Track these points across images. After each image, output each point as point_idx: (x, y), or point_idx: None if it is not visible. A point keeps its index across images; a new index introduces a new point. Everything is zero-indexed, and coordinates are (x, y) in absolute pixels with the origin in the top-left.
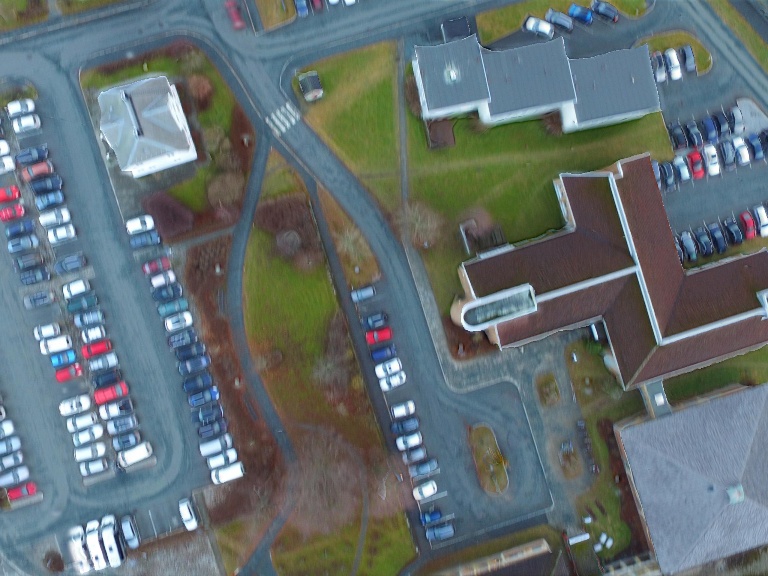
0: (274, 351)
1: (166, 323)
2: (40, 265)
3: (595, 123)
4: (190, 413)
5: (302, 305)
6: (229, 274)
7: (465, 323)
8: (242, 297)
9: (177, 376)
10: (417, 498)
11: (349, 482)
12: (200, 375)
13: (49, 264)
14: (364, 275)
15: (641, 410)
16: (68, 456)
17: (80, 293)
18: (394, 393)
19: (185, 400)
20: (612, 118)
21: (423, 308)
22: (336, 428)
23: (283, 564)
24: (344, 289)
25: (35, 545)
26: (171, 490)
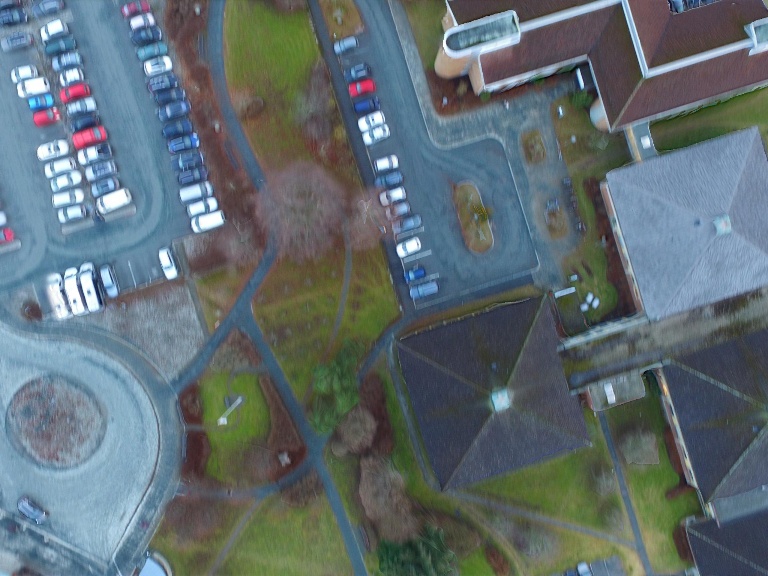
0: (255, 97)
1: (145, 66)
2: (17, 6)
3: None
4: (170, 161)
5: (283, 52)
6: (209, 20)
7: (447, 48)
8: (223, 44)
9: (157, 123)
10: (401, 255)
11: (331, 234)
12: (180, 120)
13: (27, 7)
14: (347, 27)
15: (627, 160)
16: (46, 204)
17: (58, 33)
18: (377, 149)
19: (165, 148)
20: None
21: (407, 62)
22: (318, 178)
23: (264, 316)
24: (326, 41)
25: (13, 294)
26: (151, 240)
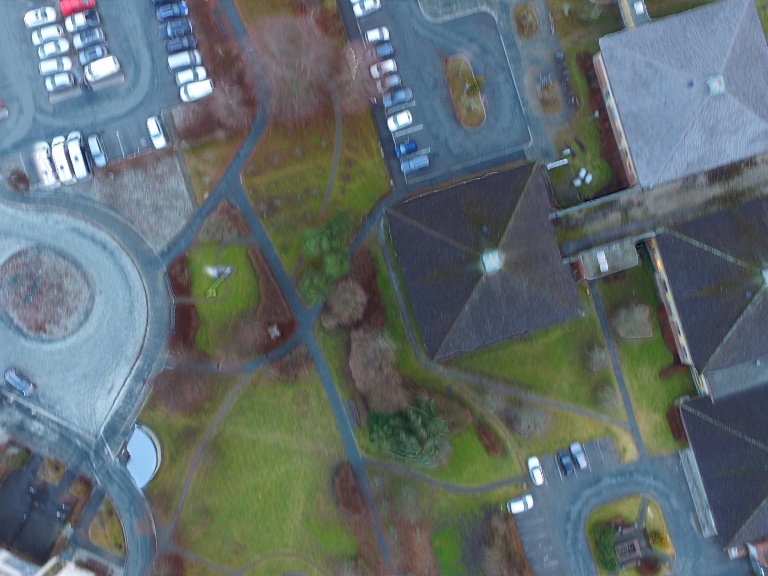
0: None
1: None
2: None
3: None
4: (158, 29)
5: None
6: None
7: None
8: None
9: None
10: (392, 128)
11: (321, 104)
12: None
13: None
14: None
15: None
16: (34, 73)
17: None
18: (368, 21)
19: (153, 16)
20: None
21: None
22: (308, 48)
23: (254, 187)
24: None
25: None
26: (139, 110)
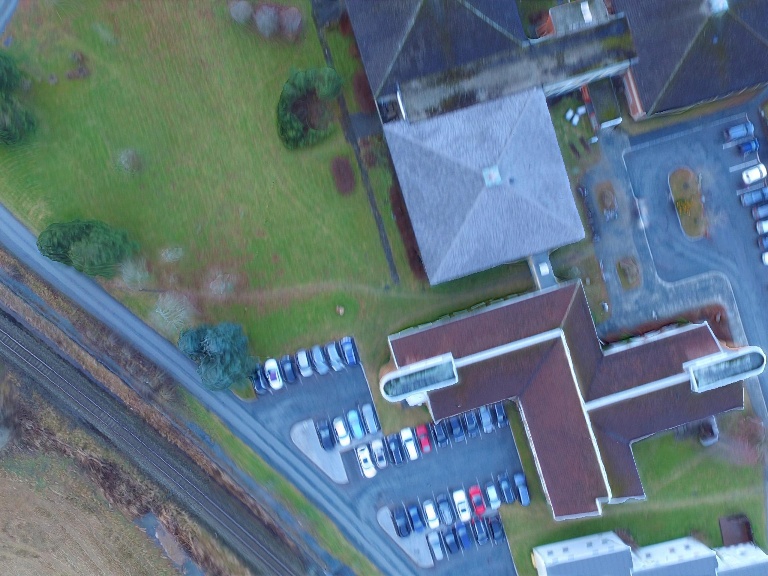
0: None
1: None
2: None
3: (611, 549)
4: None
5: None
6: None
7: (763, 355)
8: None
9: None
10: (763, 166)
11: None
12: None
13: None
14: None
15: None
16: None
17: None
18: None
19: None
20: (593, 554)
21: None
22: None
23: None
24: None
25: None
26: None
